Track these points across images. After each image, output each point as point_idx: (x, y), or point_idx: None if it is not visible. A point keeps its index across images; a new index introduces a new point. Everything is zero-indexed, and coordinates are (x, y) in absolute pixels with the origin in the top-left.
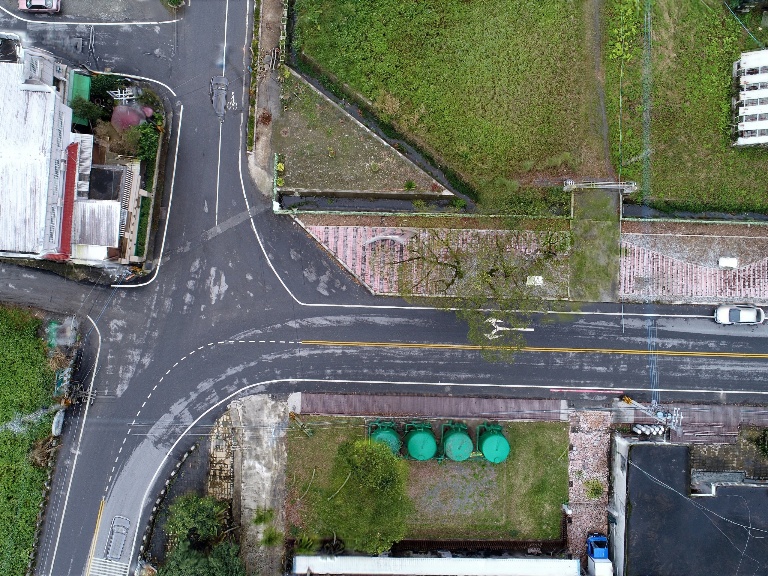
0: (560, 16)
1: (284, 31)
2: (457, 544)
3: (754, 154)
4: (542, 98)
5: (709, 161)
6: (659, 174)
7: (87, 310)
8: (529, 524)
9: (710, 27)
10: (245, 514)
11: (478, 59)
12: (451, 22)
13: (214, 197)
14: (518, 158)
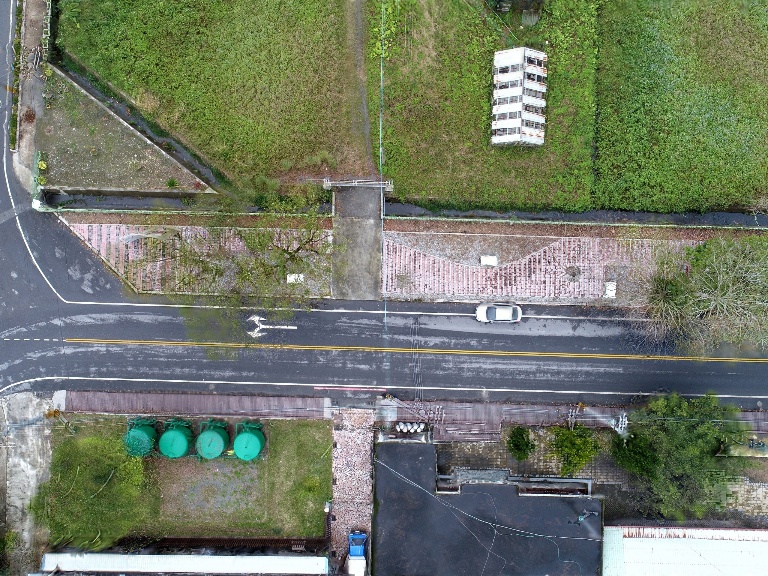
0: (321, 15)
1: (47, 29)
2: (218, 542)
3: (515, 153)
4: (303, 96)
5: (470, 159)
6: (420, 172)
7: None
8: (291, 522)
9: (471, 26)
10: (10, 512)
11: (239, 58)
12: (212, 21)
13: None
14: (279, 156)
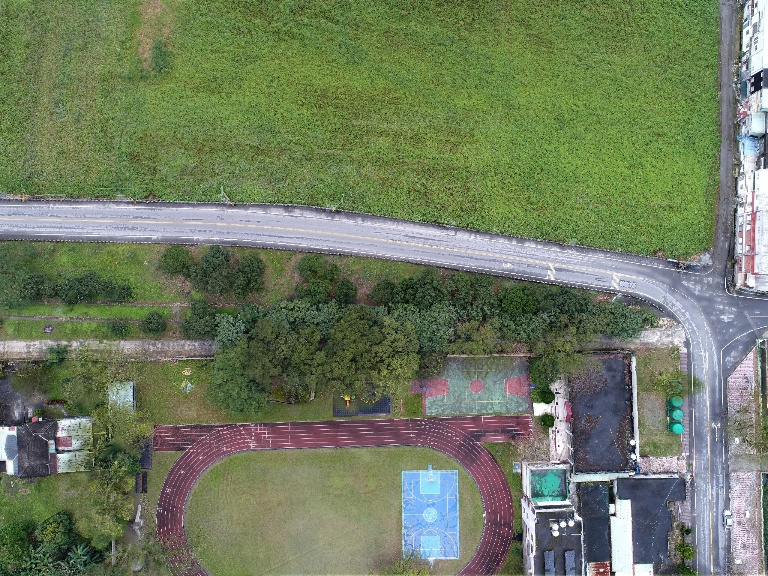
0: None
1: None
2: None
3: None
4: None
5: None
6: None
7: (715, 268)
8: (642, 443)
9: None
10: (638, 333)
11: None
12: None
13: (761, 315)
14: None
